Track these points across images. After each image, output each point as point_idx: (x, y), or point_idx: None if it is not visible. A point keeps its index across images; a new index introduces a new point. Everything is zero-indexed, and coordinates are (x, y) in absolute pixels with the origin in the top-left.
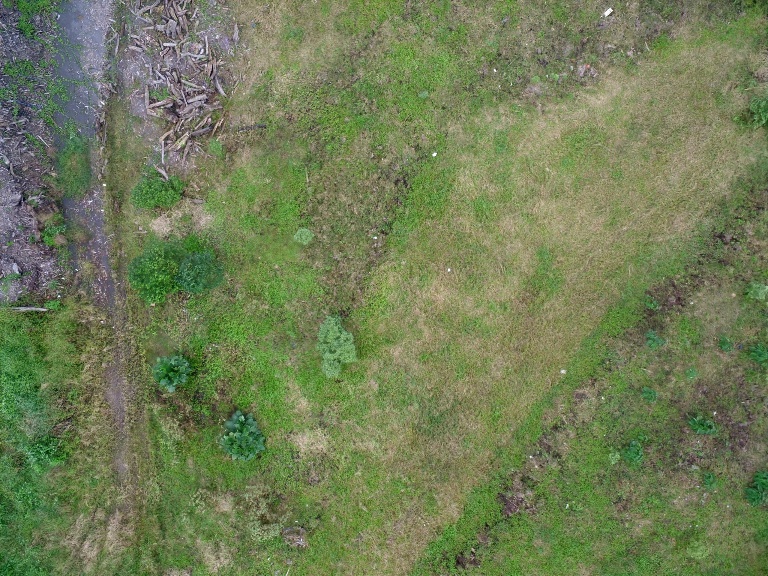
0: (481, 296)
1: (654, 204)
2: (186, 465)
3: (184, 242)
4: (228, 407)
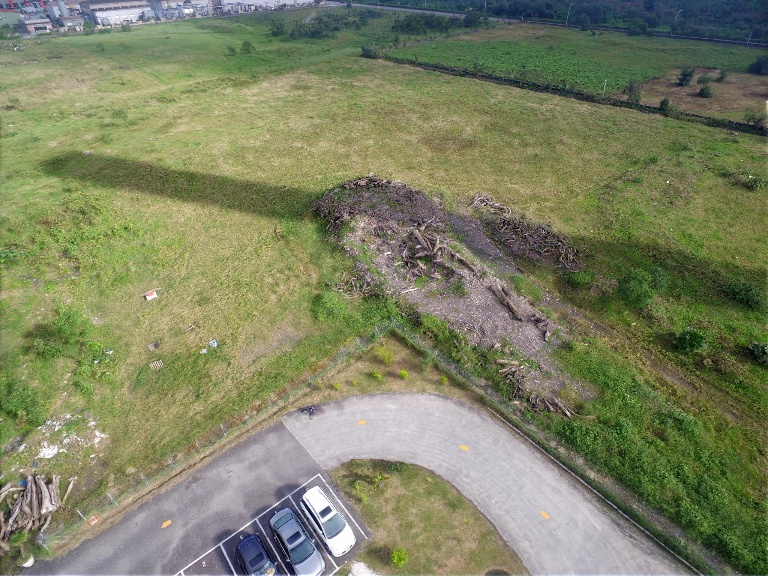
0: (764, 260)
1: (767, 215)
2: (766, 390)
3: (616, 292)
4: (739, 349)
